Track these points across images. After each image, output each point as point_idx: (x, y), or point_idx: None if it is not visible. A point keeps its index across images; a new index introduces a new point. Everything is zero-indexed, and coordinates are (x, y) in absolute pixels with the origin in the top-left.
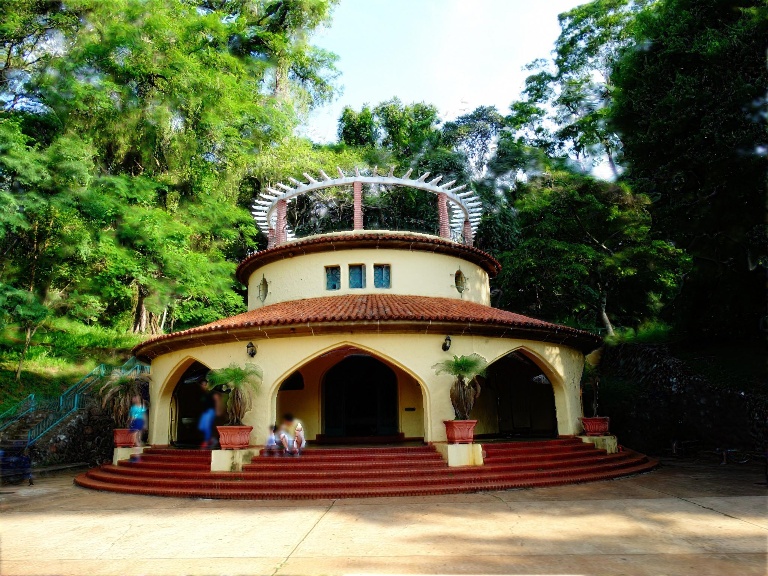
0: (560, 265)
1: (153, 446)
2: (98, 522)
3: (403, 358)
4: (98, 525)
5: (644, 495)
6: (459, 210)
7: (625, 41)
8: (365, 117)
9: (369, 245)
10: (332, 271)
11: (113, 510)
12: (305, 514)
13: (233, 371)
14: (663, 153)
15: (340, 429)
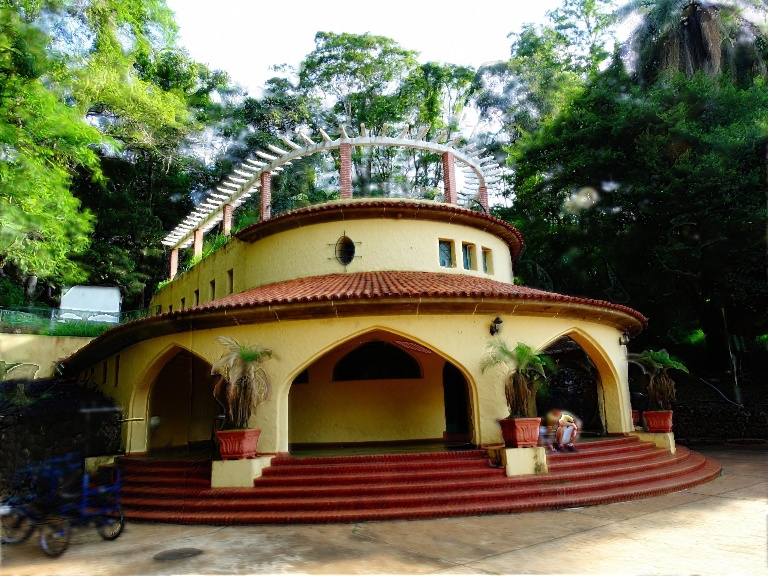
0: None
1: (278, 454)
2: (697, 543)
3: (608, 349)
4: (724, 544)
5: None
6: None
7: (372, 81)
8: (146, 54)
9: (479, 225)
10: (440, 245)
11: (587, 533)
12: None
13: None
14: (678, 205)
15: (455, 425)
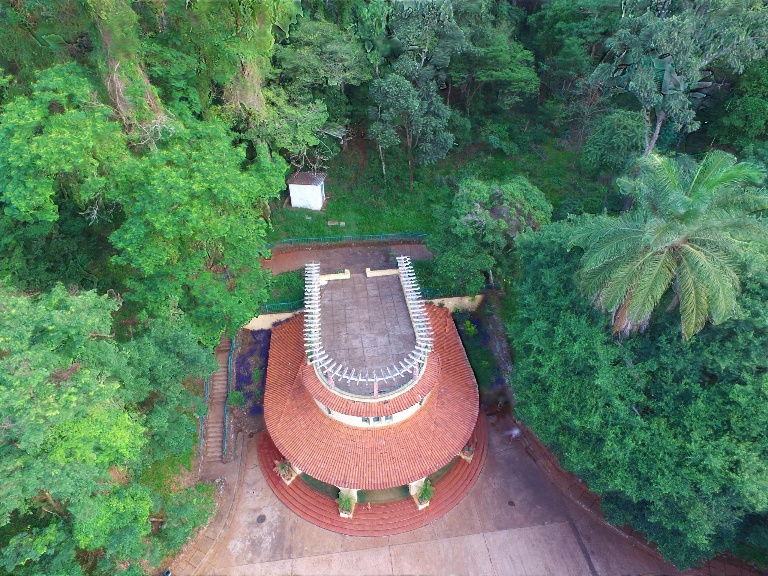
0: (470, 278)
1: (298, 474)
2: (334, 575)
3: None
4: None
5: (474, 528)
6: (421, 333)
7: None
8: None
9: None
10: None
11: (327, 556)
12: (386, 561)
13: (345, 500)
14: None
15: None
